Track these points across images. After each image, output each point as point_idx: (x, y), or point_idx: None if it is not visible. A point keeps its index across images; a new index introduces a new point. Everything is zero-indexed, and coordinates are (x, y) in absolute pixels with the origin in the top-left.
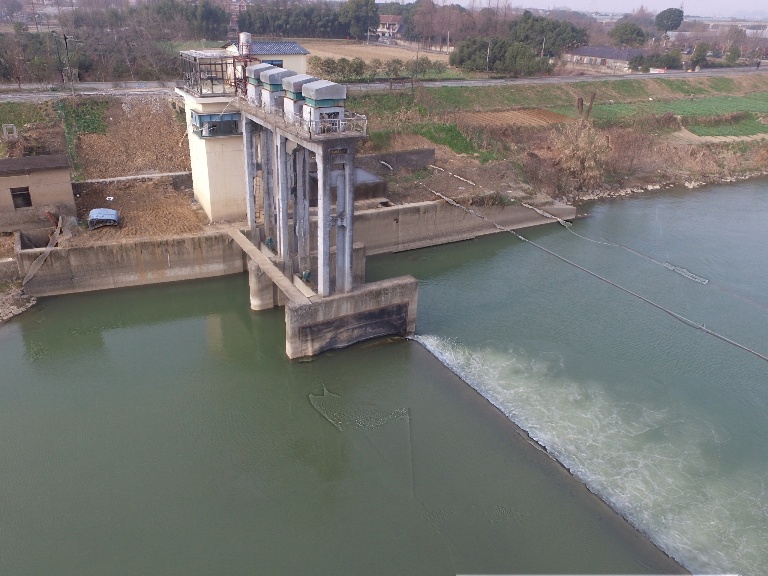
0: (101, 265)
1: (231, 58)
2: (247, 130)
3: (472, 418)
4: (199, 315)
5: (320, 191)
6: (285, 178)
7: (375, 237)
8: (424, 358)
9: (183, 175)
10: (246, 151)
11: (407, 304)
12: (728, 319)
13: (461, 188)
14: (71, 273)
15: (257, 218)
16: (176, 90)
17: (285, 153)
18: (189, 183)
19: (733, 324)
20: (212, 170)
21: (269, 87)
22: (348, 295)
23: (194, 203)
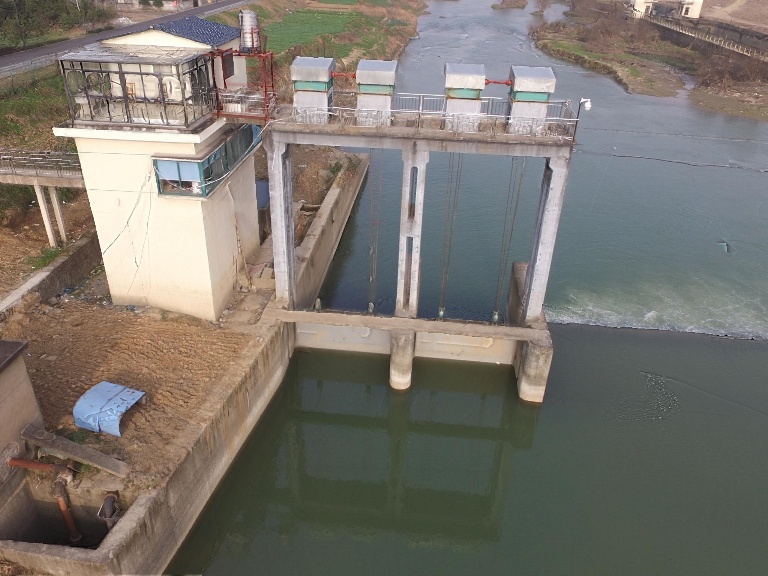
0: (197, 474)
1: (201, 56)
2: (282, 163)
3: (679, 348)
4: (269, 454)
5: (555, 201)
6: None
7: (327, 250)
8: (574, 330)
9: (43, 280)
10: (282, 194)
11: None
12: (589, 200)
13: (303, 166)
14: (171, 522)
15: (250, 286)
16: (64, 132)
17: None
18: (53, 289)
19: (595, 202)
20: (208, 243)
21: (385, 90)
22: None
23: (139, 310)
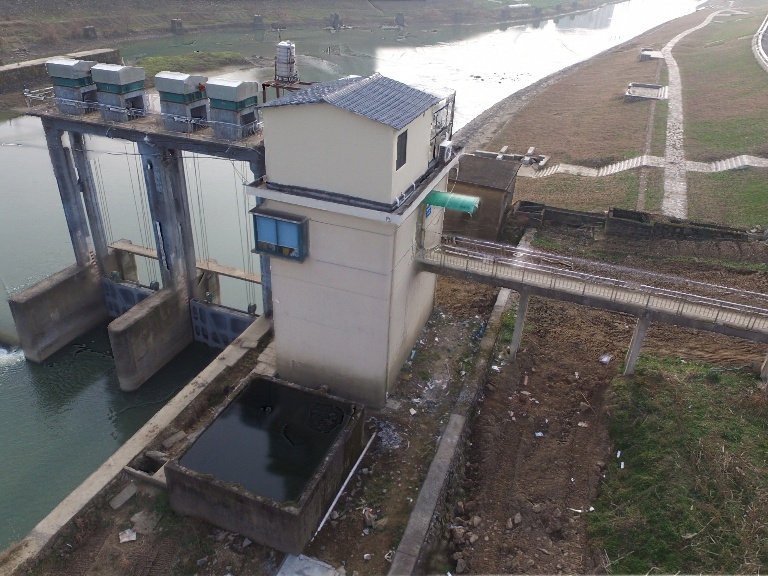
0: None
1: None
2: None
3: None
4: None
5: None
6: None
7: None
8: (5, 331)
9: None
10: None
11: None
12: None
13: None
14: None
15: None
16: None
17: None
18: None
19: None
20: None
21: None
22: None
23: None
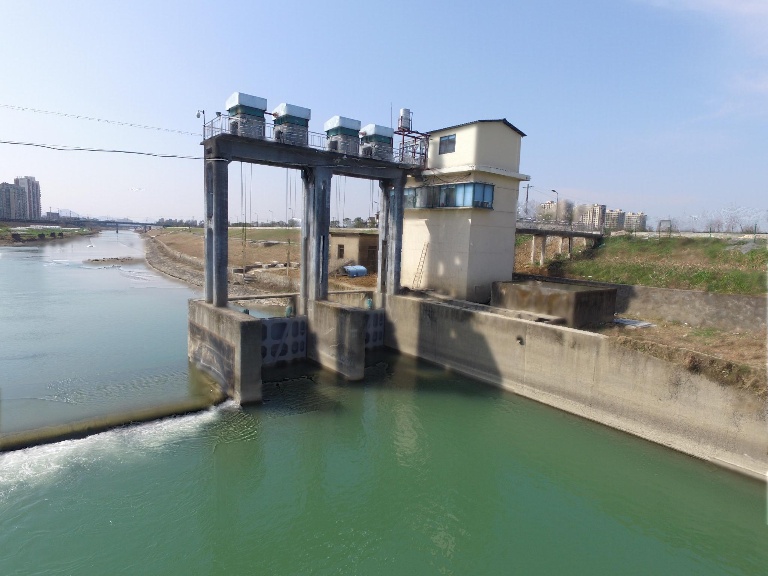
0: None
1: None
2: (382, 194)
3: None
4: None
5: None
6: (304, 213)
7: (490, 354)
8: (166, 402)
9: None
10: None
11: (234, 349)
12: None
13: None
14: None
15: None
16: None
17: (305, 188)
18: None
19: None
20: None
21: None
22: (208, 306)
23: None
